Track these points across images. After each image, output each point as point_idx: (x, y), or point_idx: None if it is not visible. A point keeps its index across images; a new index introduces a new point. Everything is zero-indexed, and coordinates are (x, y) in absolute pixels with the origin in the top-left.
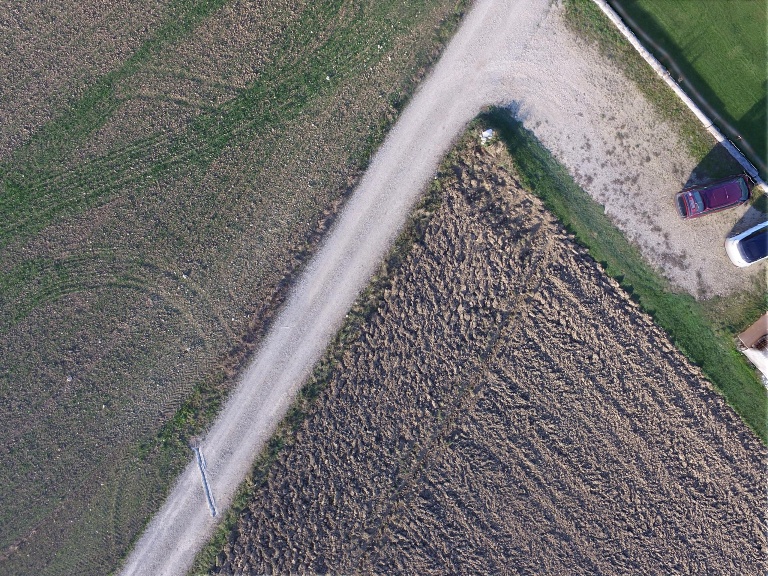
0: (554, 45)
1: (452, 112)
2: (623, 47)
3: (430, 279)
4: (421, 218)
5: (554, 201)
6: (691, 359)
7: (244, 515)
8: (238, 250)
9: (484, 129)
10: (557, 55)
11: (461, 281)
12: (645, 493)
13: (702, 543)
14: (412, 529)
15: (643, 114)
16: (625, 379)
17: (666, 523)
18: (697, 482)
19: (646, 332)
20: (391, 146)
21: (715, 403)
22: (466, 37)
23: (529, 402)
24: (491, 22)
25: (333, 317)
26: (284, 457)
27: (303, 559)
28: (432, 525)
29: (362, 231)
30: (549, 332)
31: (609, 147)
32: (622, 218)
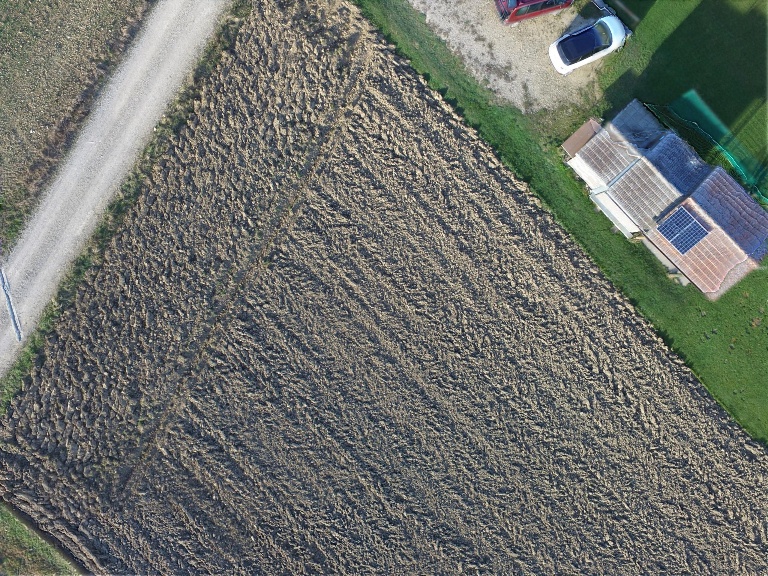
0: None
1: None
2: None
3: (242, 90)
4: (229, 24)
5: (373, 9)
6: (518, 175)
7: (50, 337)
8: (34, 57)
9: None
10: None
11: (276, 93)
12: (472, 313)
13: (532, 364)
14: (231, 353)
15: None
16: (450, 196)
17: (494, 344)
18: (526, 302)
19: (471, 147)
20: None
21: (544, 220)
22: None
23: (351, 220)
24: None
25: (140, 131)
26: (92, 277)
27: (116, 384)
28: (251, 348)
29: (169, 40)
30: (370, 147)
31: None
32: (444, 27)
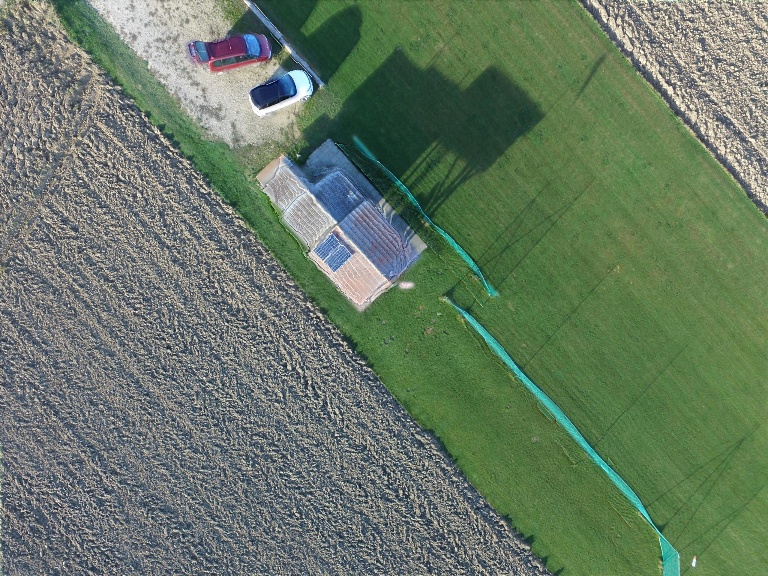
0: None
1: None
2: None
3: None
4: None
5: (101, 55)
6: (225, 200)
7: None
8: None
9: None
10: None
11: (15, 124)
12: (183, 316)
13: (234, 361)
14: None
15: None
16: (166, 215)
17: (202, 343)
18: (231, 308)
19: (185, 175)
20: None
21: (247, 239)
22: None
23: (79, 234)
24: None
25: None
26: None
27: None
28: None
29: None
30: (97, 172)
31: (151, 9)
32: (164, 73)
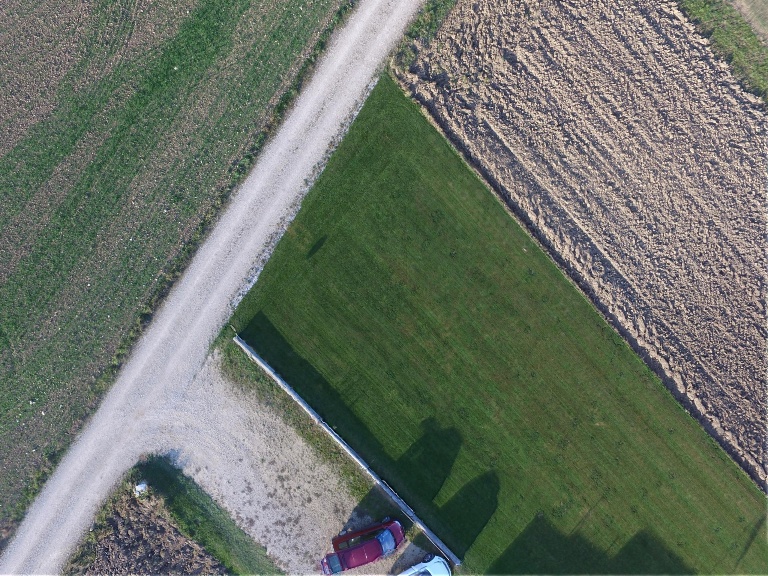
0: (211, 395)
1: (111, 460)
2: (280, 395)
3: None
4: (73, 574)
5: (215, 545)
6: None
7: None
8: None
9: (138, 482)
10: (214, 405)
11: None
12: None
13: None
14: None
15: (302, 457)
16: None
17: None
18: None
19: None
20: (49, 496)
21: None
22: (125, 387)
23: None
24: (151, 371)
25: None
26: None
27: None
28: None
29: None
30: None
31: (270, 490)
32: (284, 559)
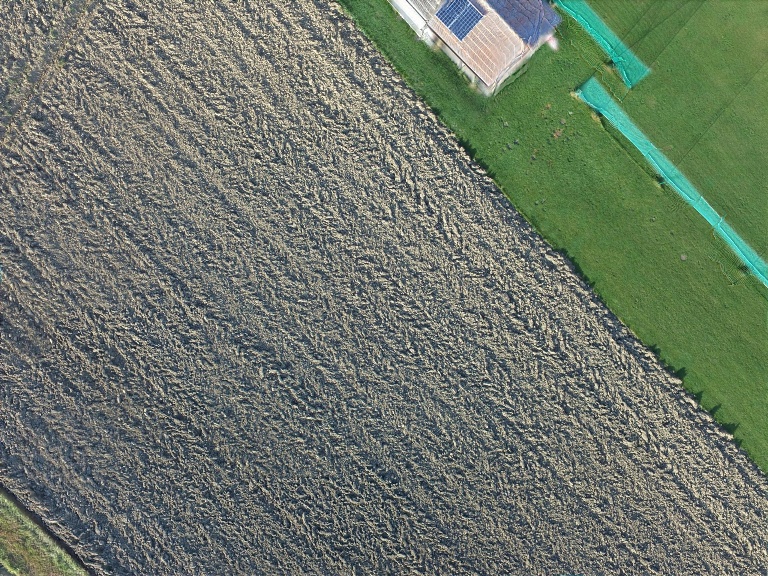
0: None
1: None
2: None
3: None
4: None
5: None
6: None
7: None
8: None
9: None
10: None
11: None
12: (273, 119)
13: (334, 172)
14: (26, 154)
15: None
16: None
17: (296, 151)
18: (328, 110)
19: None
20: None
21: (345, 27)
22: None
23: (148, 22)
24: None
25: None
26: None
27: None
28: (47, 149)
29: None
30: None
31: None
32: None
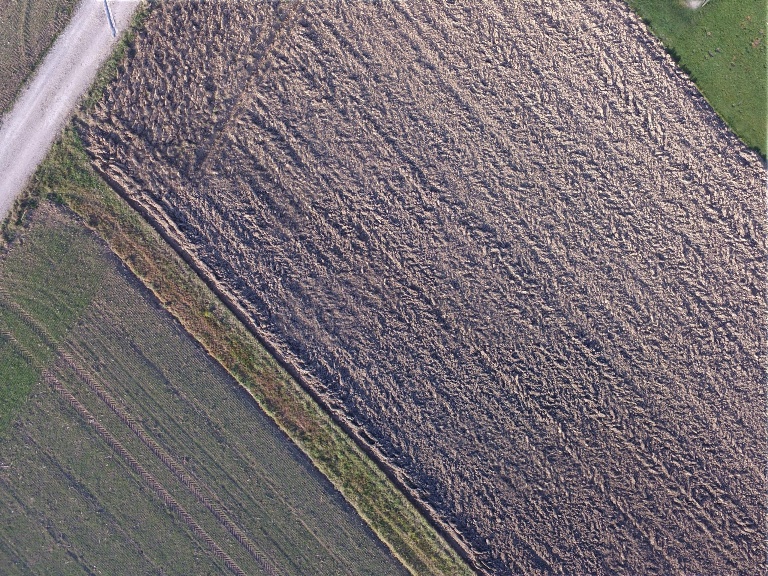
0: None
1: None
2: None
3: None
4: None
5: None
6: None
7: (141, 33)
8: None
9: None
10: None
11: None
12: (503, 28)
13: (553, 75)
14: (292, 55)
15: None
16: None
17: (521, 56)
18: (550, 20)
19: None
20: None
21: None
22: None
23: None
24: None
25: None
26: None
27: (194, 78)
28: (310, 51)
29: None
30: None
31: None
32: None
